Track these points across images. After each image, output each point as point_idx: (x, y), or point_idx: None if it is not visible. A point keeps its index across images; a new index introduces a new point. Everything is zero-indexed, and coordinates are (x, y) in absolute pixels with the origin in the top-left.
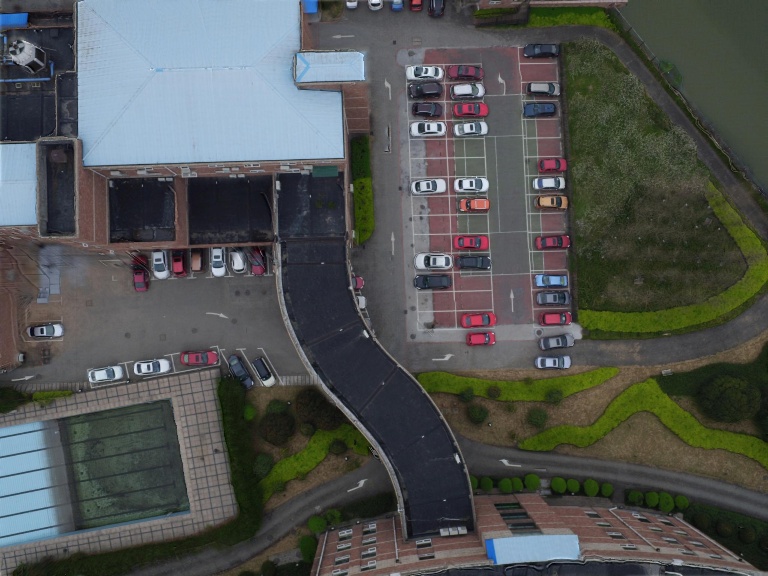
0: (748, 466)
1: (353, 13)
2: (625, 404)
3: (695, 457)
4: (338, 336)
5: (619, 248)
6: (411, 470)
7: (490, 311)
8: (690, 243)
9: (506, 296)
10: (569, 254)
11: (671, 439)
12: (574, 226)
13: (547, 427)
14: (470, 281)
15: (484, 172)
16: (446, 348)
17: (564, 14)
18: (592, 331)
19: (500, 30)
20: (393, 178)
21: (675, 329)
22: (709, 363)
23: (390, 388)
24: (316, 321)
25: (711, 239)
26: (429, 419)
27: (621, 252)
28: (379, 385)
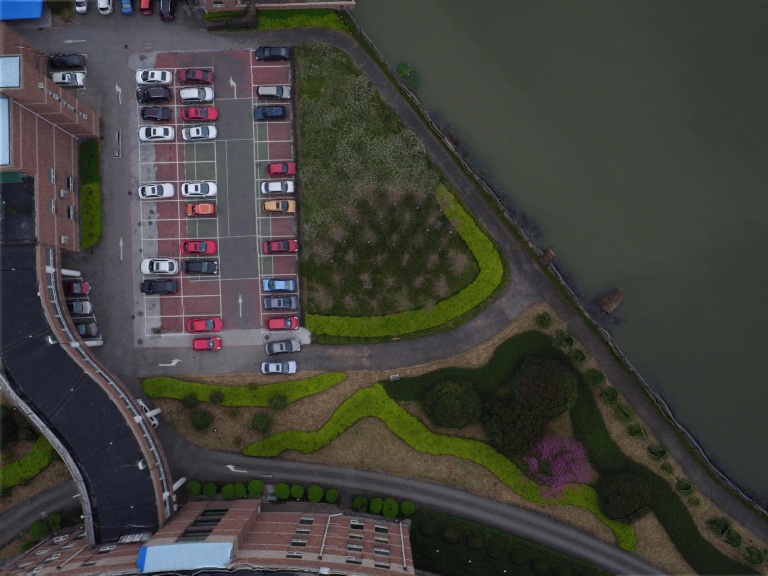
0: (478, 472)
1: (85, 18)
2: (350, 409)
3: (424, 463)
4: (29, 342)
5: (348, 252)
6: (100, 477)
7: (217, 316)
8: (421, 246)
9: (234, 301)
10: (299, 258)
11: (399, 445)
12: (302, 230)
13: (273, 433)
14: (198, 286)
15: (214, 176)
16: (173, 353)
17: (295, 16)
18: (320, 336)
19: (233, 33)
20: (122, 183)
21: (404, 333)
22: (439, 368)
23: (80, 394)
24: (7, 327)
25: (443, 242)
26: (118, 425)
27: (350, 256)
28: (69, 391)
